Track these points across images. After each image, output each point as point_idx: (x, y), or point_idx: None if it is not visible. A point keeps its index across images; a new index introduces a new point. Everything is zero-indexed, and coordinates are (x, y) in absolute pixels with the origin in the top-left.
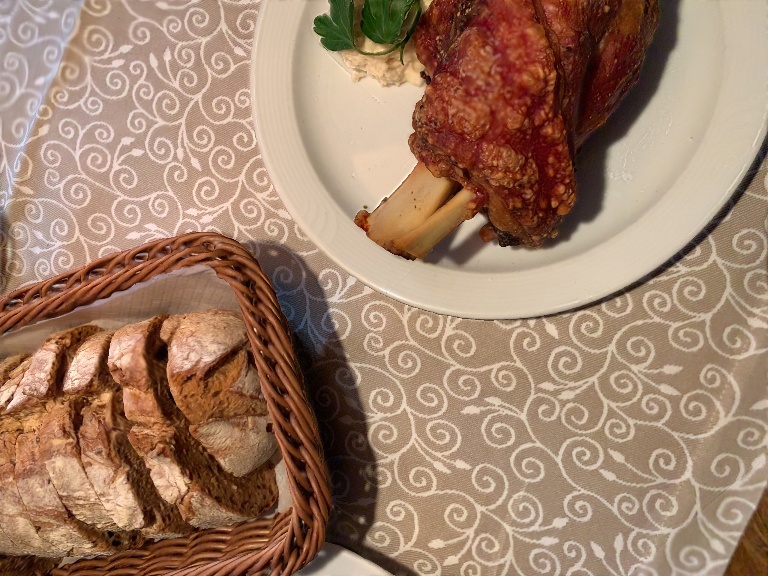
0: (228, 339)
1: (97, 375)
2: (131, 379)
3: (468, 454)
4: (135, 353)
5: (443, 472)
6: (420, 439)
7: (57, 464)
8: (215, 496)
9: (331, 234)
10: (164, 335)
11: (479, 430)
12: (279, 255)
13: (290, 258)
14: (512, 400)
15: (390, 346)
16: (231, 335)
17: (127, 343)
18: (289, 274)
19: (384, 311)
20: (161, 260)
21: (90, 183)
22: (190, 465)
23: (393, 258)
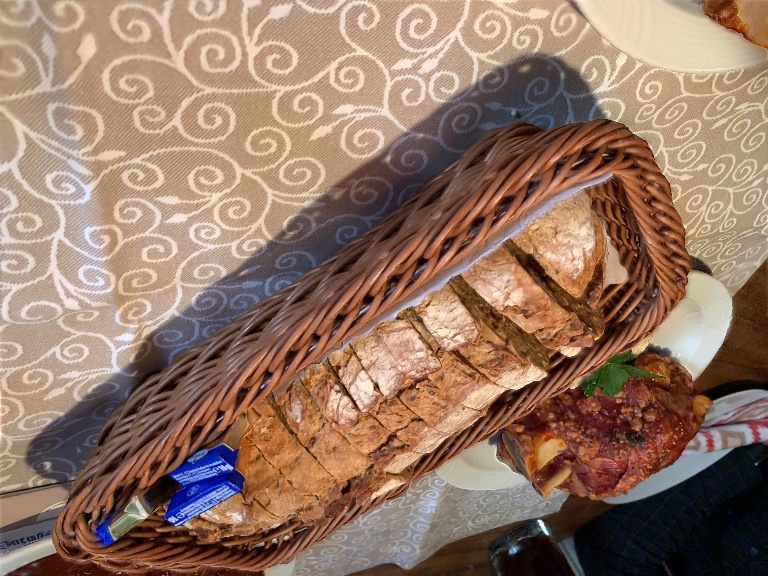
0: (585, 212)
1: (474, 320)
2: (539, 309)
3: (709, 157)
4: (525, 286)
5: (687, 180)
6: (672, 167)
7: (473, 397)
8: (602, 327)
9: (645, 32)
10: (529, 249)
11: (722, 135)
12: (532, 67)
13: (546, 65)
14: (758, 98)
15: (662, 107)
16: (584, 206)
17: (502, 280)
18: (545, 83)
19: (660, 77)
20: (540, 192)
21: (223, 96)
22: (592, 326)
23: (710, 29)
